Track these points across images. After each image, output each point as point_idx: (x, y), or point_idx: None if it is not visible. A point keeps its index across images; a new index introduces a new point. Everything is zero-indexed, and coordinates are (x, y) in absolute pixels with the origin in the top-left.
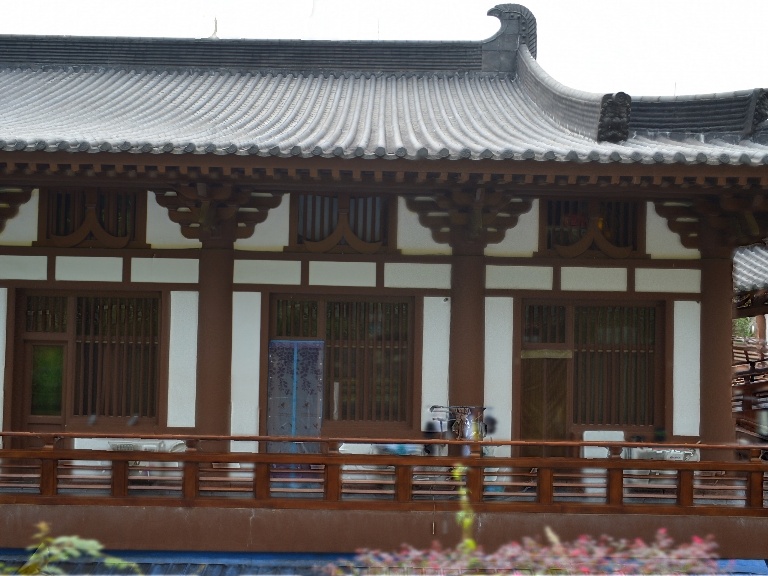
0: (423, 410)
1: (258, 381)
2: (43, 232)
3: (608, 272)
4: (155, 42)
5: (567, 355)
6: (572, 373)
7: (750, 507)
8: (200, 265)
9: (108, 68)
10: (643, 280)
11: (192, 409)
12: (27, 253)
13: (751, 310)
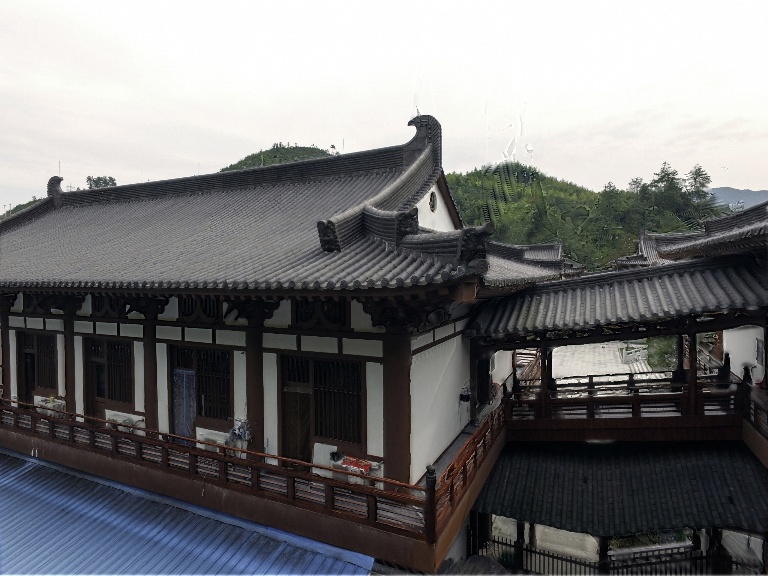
0: (235, 417)
1: (167, 391)
2: (93, 309)
3: (326, 340)
4: (234, 174)
5: (310, 392)
6: (314, 403)
7: (367, 519)
8: (143, 328)
9: (215, 191)
10: (347, 346)
11: (143, 403)
12: (87, 320)
13: (592, 338)
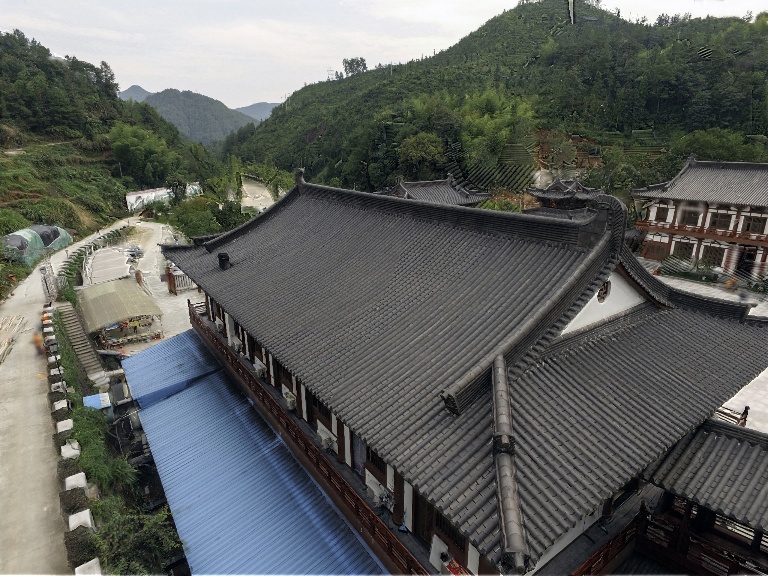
0: (387, 480)
1: (349, 434)
2: None
3: None
4: (422, 205)
5: None
6: None
7: None
8: None
9: (407, 216)
10: None
11: None
12: None
13: None
